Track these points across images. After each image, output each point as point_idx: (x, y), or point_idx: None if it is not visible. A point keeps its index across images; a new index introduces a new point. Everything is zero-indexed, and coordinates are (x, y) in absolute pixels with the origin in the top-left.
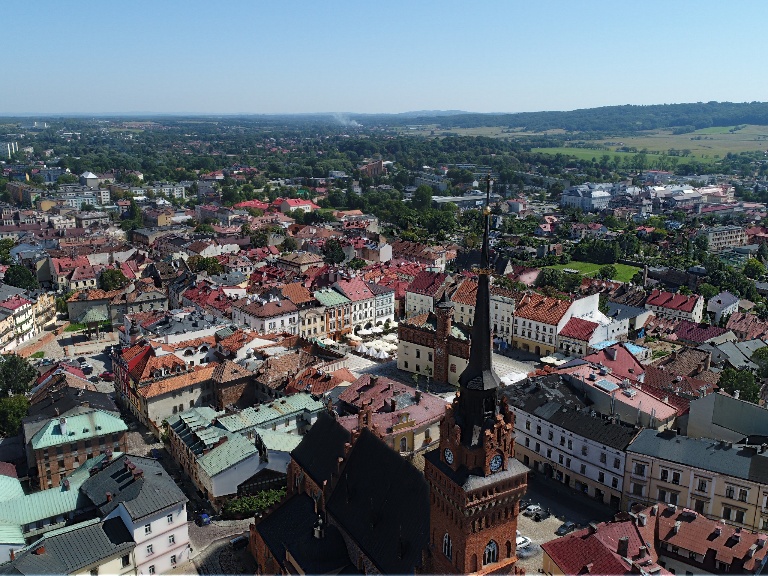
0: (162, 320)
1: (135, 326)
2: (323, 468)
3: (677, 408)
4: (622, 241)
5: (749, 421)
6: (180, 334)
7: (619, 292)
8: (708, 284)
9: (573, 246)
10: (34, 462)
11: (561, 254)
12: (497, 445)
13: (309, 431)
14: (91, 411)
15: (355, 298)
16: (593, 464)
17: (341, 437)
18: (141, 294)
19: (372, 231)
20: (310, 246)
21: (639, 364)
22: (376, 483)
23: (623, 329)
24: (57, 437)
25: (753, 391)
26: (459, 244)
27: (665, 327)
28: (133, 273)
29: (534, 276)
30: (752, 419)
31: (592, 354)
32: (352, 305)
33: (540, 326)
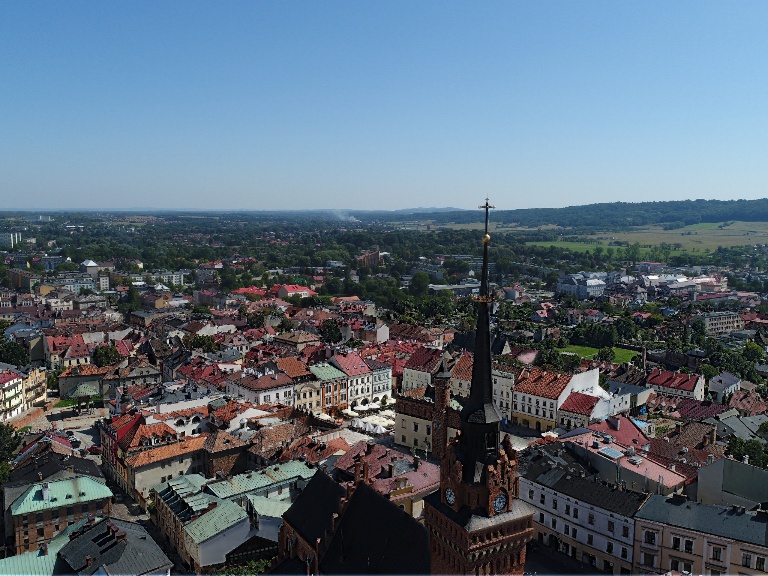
0: (154, 392)
1: (126, 394)
2: (317, 528)
3: (685, 476)
4: (619, 325)
5: (761, 487)
6: (172, 404)
7: (619, 372)
8: (708, 365)
9: (570, 330)
10: (12, 530)
11: (559, 338)
12: (501, 483)
13: (303, 491)
14: (76, 476)
15: (352, 373)
16: (600, 533)
17: (336, 494)
18: (134, 369)
19: (369, 314)
20: (307, 326)
21: (643, 435)
22: (373, 538)
23: (625, 404)
24: (38, 503)
25: (762, 460)
26: (456, 328)
27: (667, 405)
28: (128, 351)
29: (532, 357)
30: (764, 485)
31: (594, 423)
32: (349, 380)
33: (540, 401)
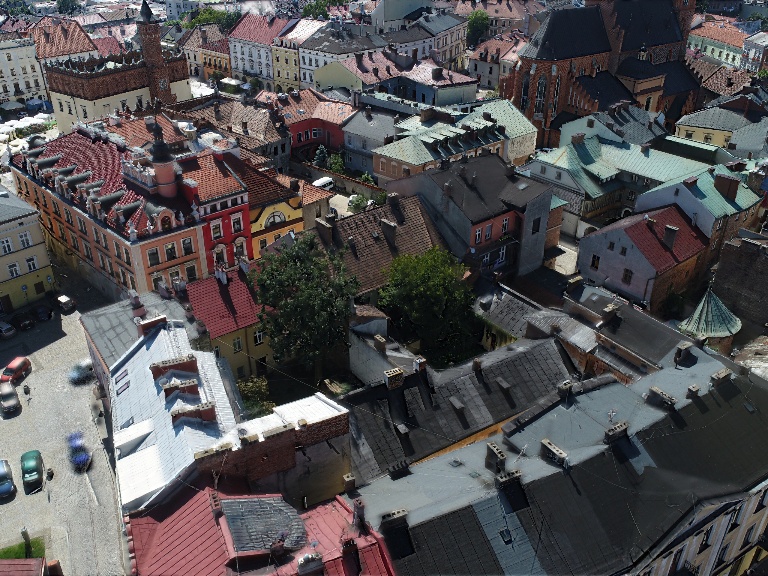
0: None
1: (163, 140)
2: None
3: None
4: None
5: None
6: None
7: None
8: None
9: None
10: None
11: None
12: None
13: None
14: None
15: None
16: None
17: None
18: None
19: None
20: None
21: None
22: None
23: None
24: None
25: None
26: None
27: None
28: None
29: None
30: None
31: None
32: None
33: None
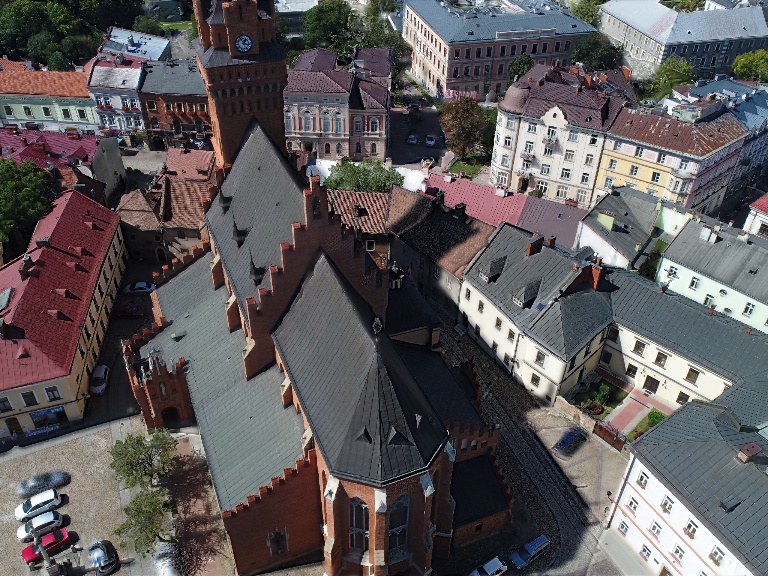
0: None
1: None
2: None
3: None
4: None
5: None
6: None
7: None
8: None
9: None
10: None
11: None
12: None
13: None
14: None
15: None
16: None
17: None
18: None
19: None
20: None
21: None
22: None
23: None
24: None
25: None
26: None
27: None
28: None
29: None
30: None
31: None
32: None
33: None
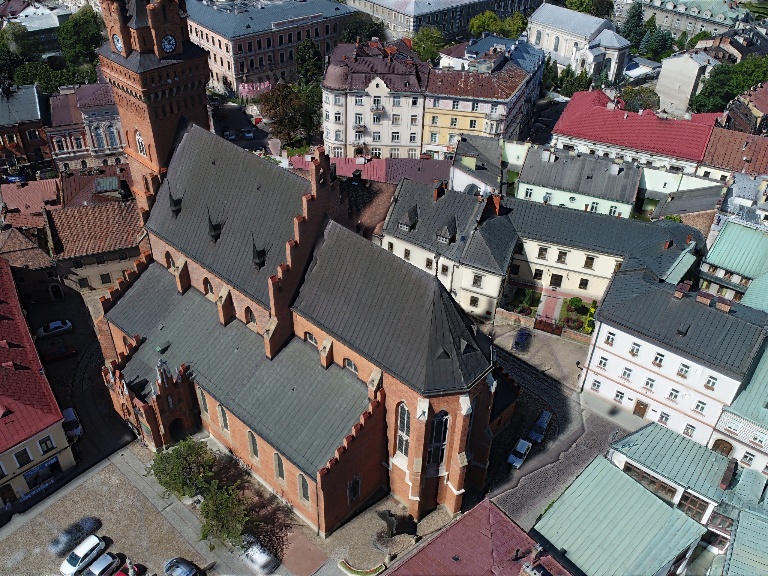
0: None
1: None
2: None
3: None
4: None
5: None
6: None
7: None
8: None
9: None
10: None
11: None
12: None
13: None
14: None
15: None
16: None
17: None
18: None
19: None
20: None
21: None
22: None
23: None
24: None
25: None
26: None
27: None
28: None
29: None
30: None
31: None
32: None
33: None
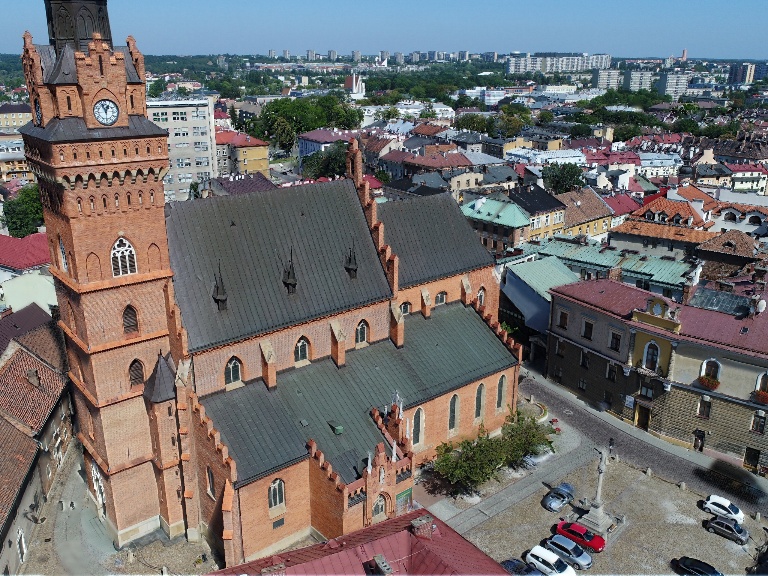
0: None
1: (686, 165)
2: None
3: None
4: None
5: None
6: None
7: None
8: None
9: None
10: None
11: None
12: None
13: None
14: (509, 201)
15: None
16: None
17: None
18: None
19: None
20: None
21: None
22: None
23: None
24: (470, 210)
25: None
26: None
27: None
28: None
29: None
30: None
31: None
32: None
33: None
